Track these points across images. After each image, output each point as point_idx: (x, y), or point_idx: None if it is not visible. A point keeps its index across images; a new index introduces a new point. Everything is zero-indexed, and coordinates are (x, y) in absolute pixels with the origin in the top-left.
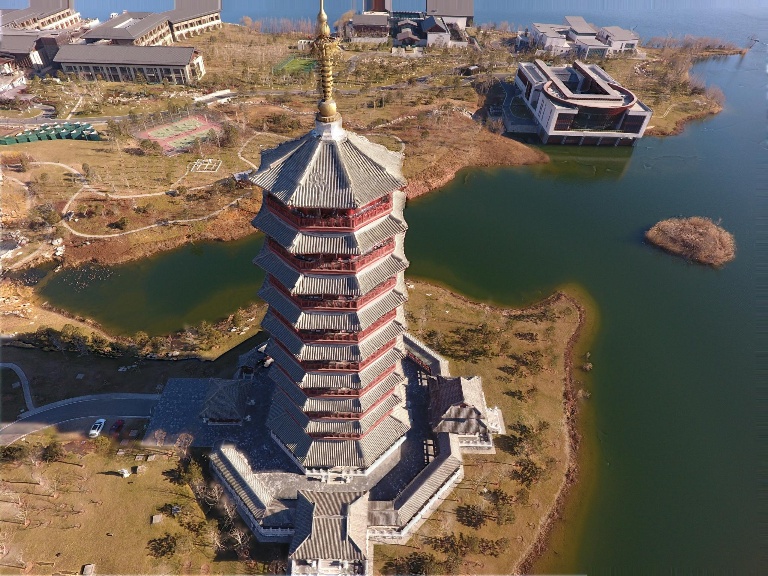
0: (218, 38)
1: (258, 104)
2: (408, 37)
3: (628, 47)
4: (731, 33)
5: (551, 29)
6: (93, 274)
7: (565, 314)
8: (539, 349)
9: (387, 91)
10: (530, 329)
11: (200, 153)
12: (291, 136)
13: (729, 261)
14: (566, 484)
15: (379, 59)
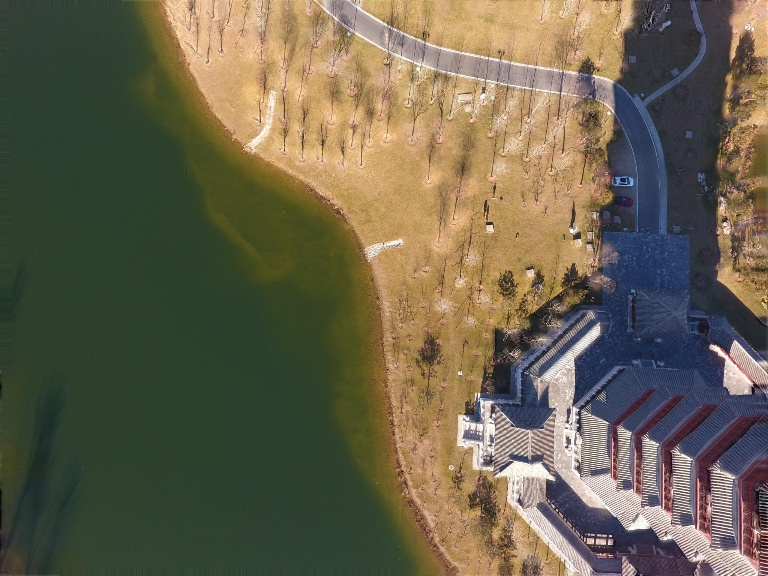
0: None
1: None
2: None
3: None
4: None
5: None
6: None
7: None
8: None
9: None
10: None
11: None
12: None
13: None
14: None
15: None
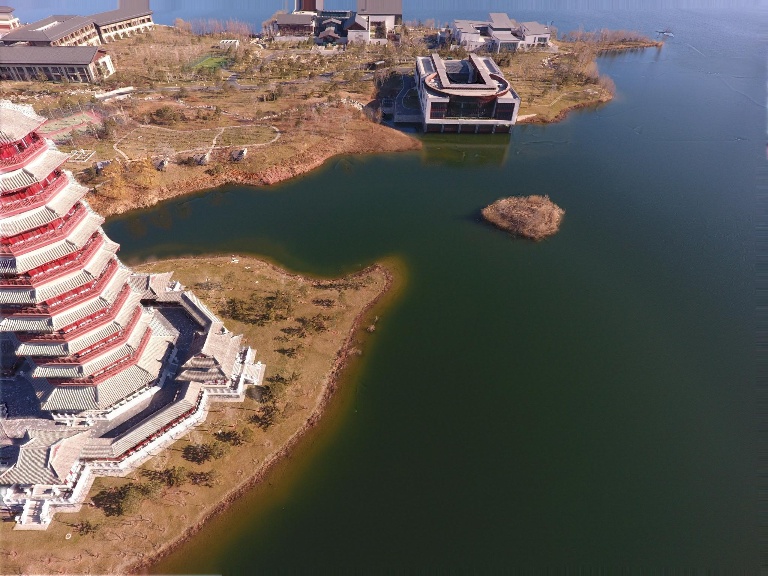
0: (145, 39)
1: (155, 100)
2: (328, 35)
3: (541, 41)
4: (646, 26)
5: (470, 25)
6: None
7: (368, 283)
8: (331, 313)
9: (288, 86)
10: (330, 296)
11: (76, 145)
12: (173, 128)
13: (552, 235)
14: (305, 427)
15: (296, 56)
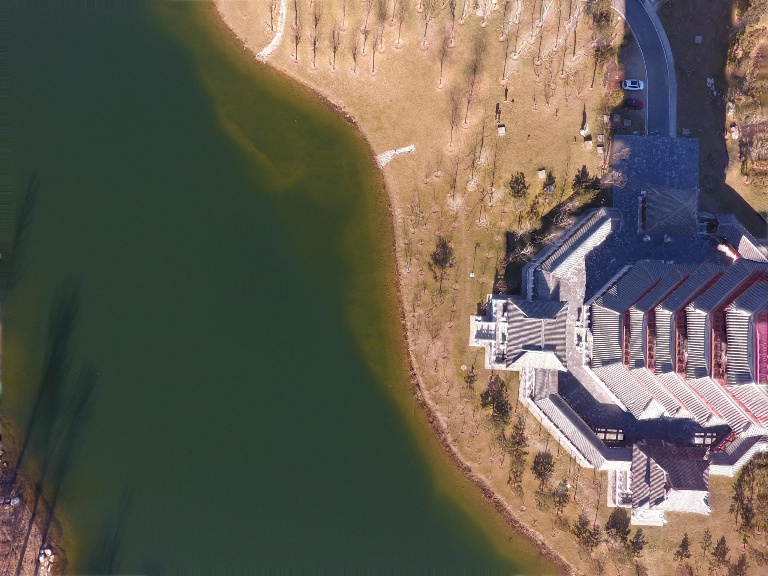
0: None
1: None
2: None
3: None
4: None
5: None
6: None
7: None
8: None
9: None
10: None
11: None
12: None
13: None
14: (575, 572)
15: None
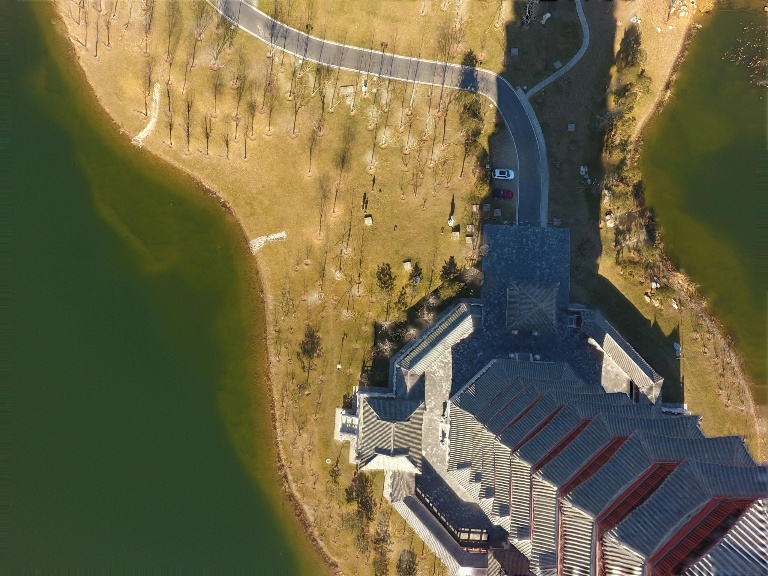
0: None
1: None
2: None
3: None
4: None
5: None
6: (762, 61)
7: None
8: None
9: None
10: None
11: None
12: None
13: None
14: None
15: None
